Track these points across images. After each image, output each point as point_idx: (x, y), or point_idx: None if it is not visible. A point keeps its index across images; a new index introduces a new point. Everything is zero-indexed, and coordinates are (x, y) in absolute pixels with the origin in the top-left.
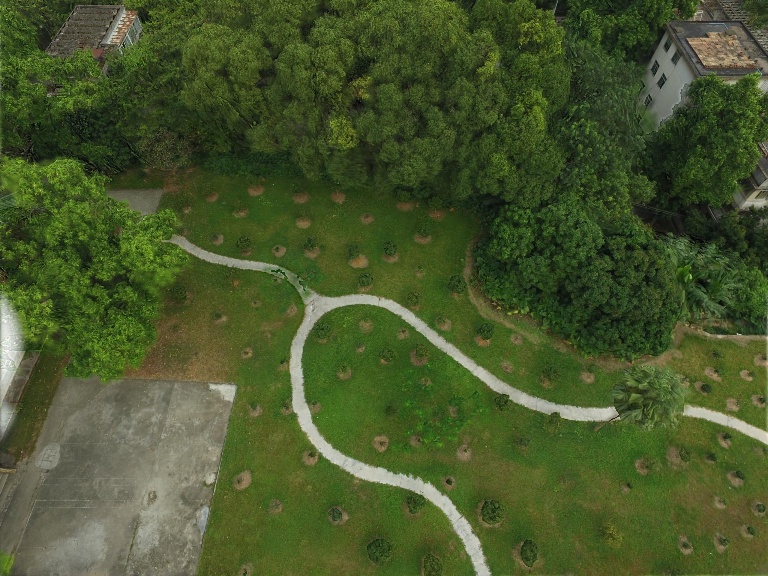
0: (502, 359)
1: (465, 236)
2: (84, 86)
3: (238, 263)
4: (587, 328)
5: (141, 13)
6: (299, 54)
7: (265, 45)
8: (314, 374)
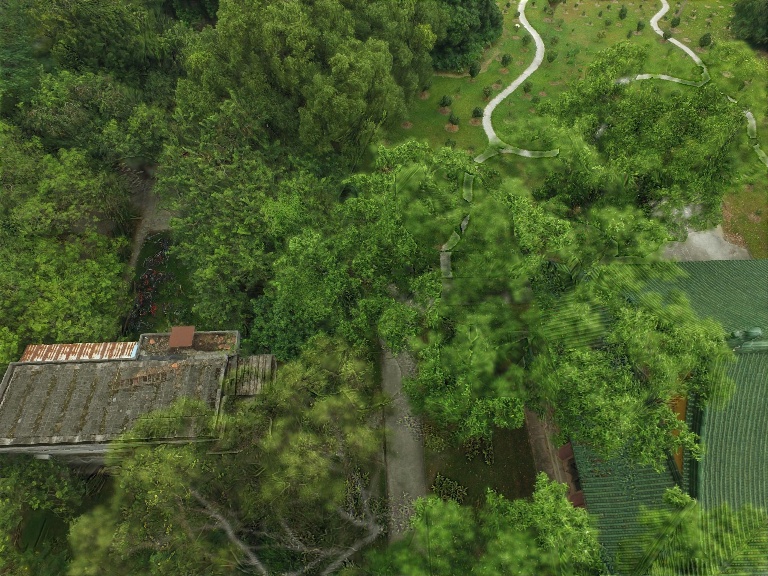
0: (515, 65)
1: None
2: None
3: None
4: (491, 27)
5: None
6: None
7: None
8: (553, 143)
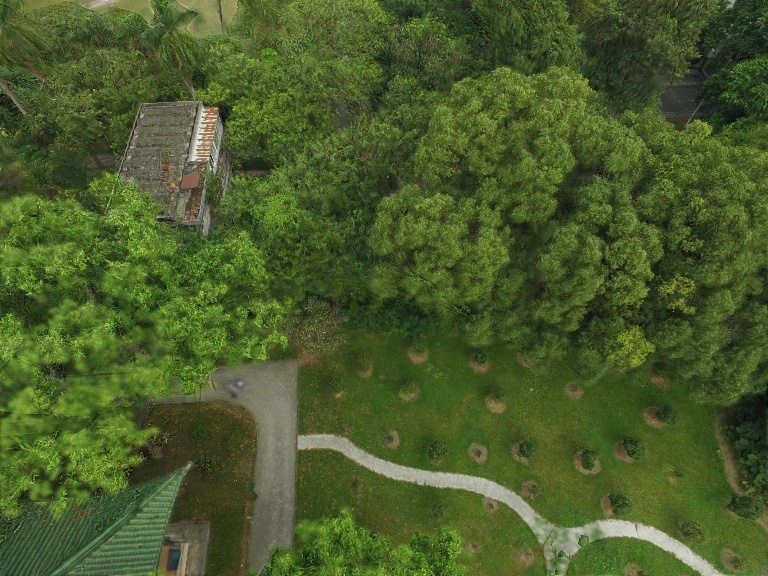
0: None
1: (707, 411)
2: (267, 309)
3: (430, 478)
4: None
5: (221, 108)
6: (594, 255)
7: (507, 221)
8: None
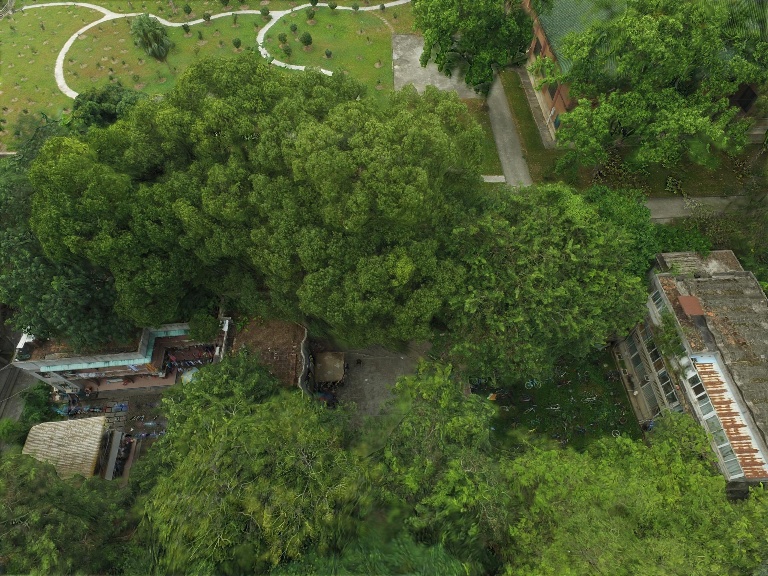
0: None
1: None
2: None
3: None
4: None
5: None
6: None
7: None
8: None
